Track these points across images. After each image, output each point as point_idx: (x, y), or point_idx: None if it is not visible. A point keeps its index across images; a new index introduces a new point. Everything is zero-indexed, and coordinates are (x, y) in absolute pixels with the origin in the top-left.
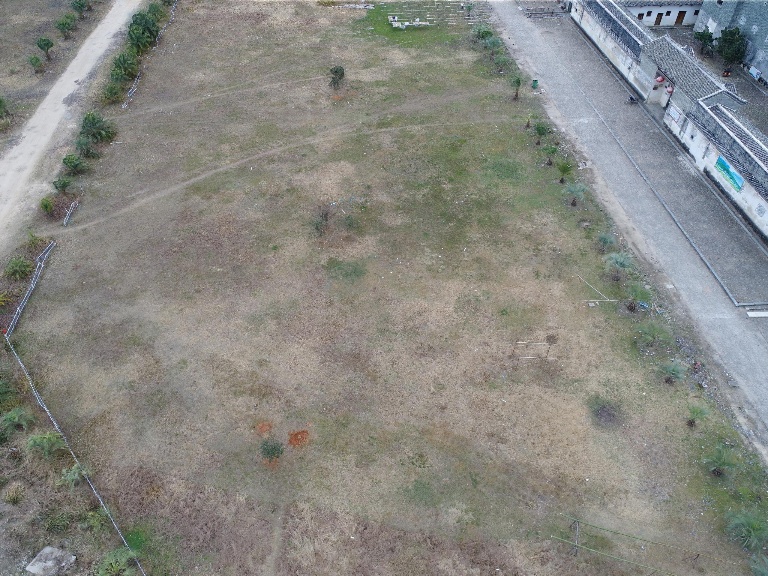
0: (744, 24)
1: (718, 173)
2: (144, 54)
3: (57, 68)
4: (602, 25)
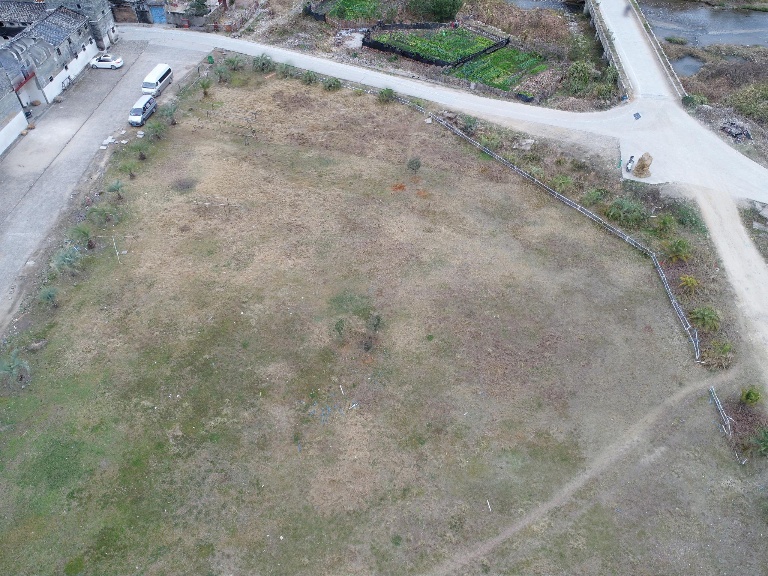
0: None
1: None
2: None
3: None
4: None
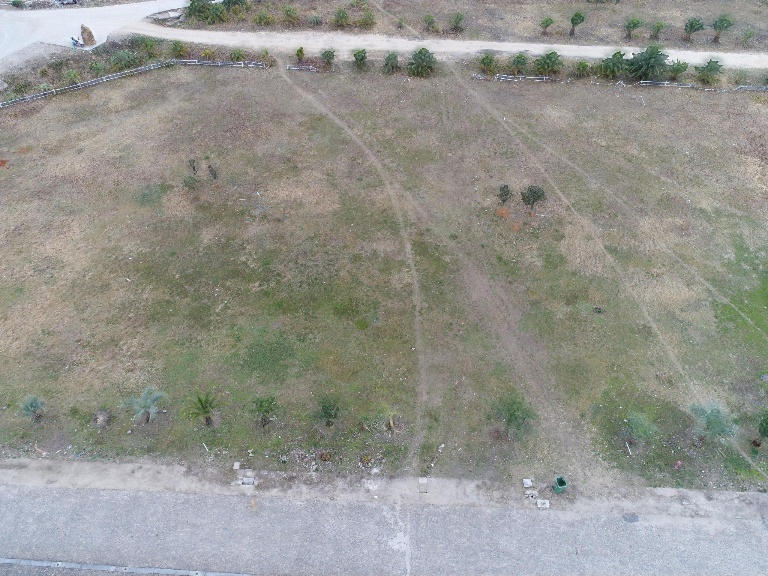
0: None
1: None
2: (603, 79)
3: (556, 40)
4: None
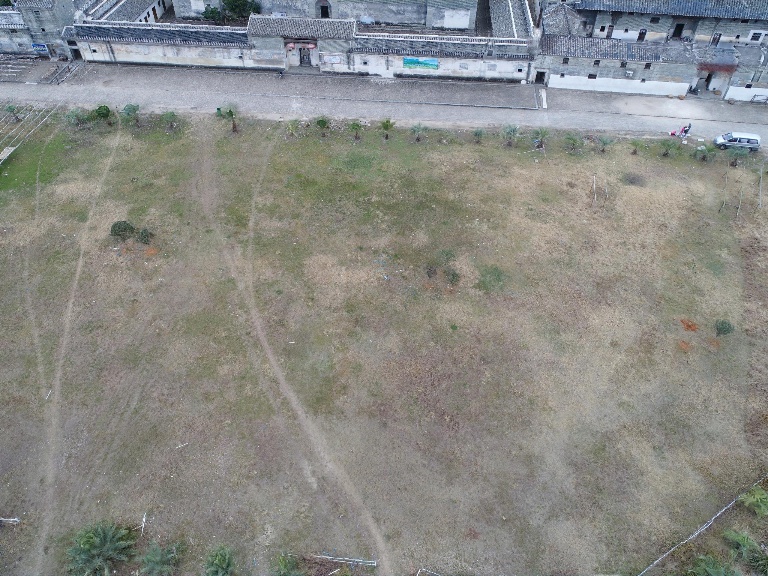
0: None
1: (410, 69)
2: None
3: None
4: (166, 43)
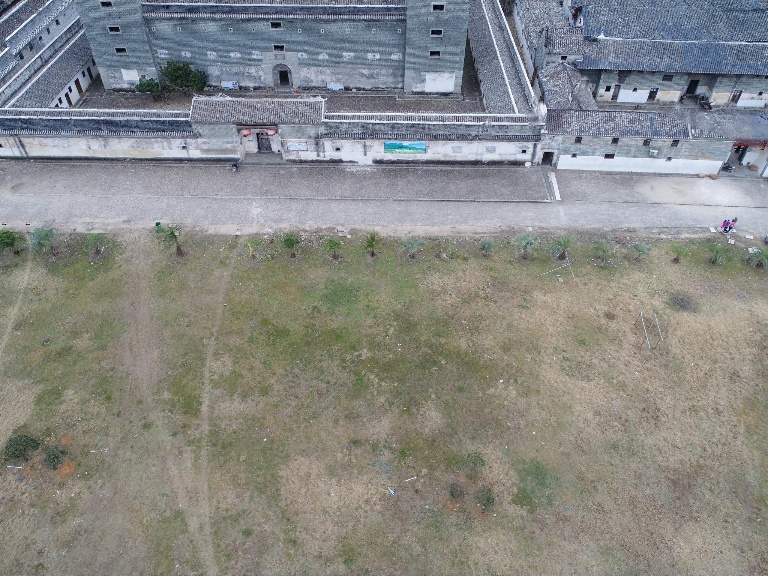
0: (168, 56)
1: (393, 154)
2: None
3: None
4: (89, 134)
